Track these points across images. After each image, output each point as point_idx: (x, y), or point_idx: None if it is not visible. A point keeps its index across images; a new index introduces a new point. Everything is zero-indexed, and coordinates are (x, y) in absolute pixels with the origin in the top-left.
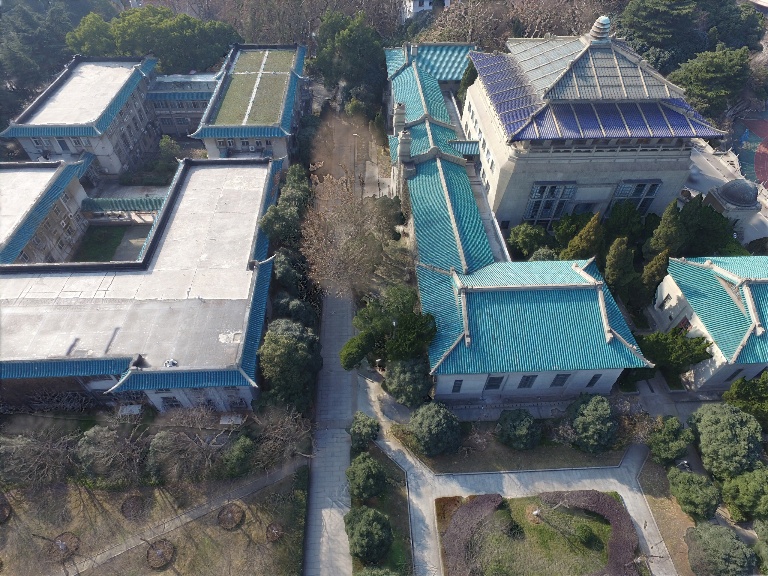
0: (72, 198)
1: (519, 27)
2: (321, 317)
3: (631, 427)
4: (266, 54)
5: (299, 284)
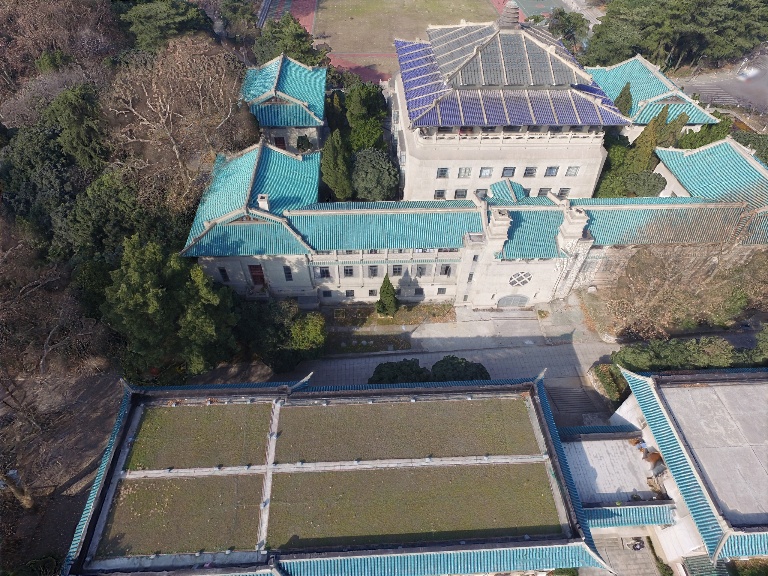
0: None
1: None
2: None
3: None
4: (147, 475)
5: None
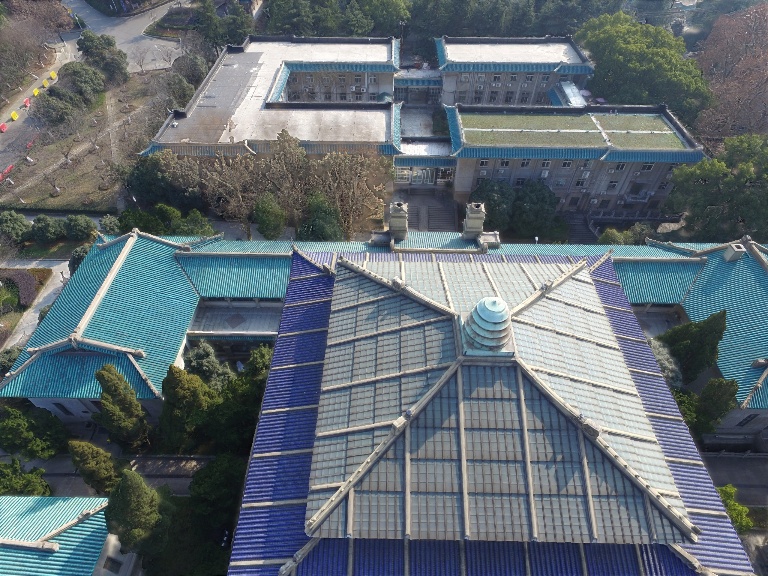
0: (378, 84)
1: None
2: None
3: None
4: (662, 132)
5: None
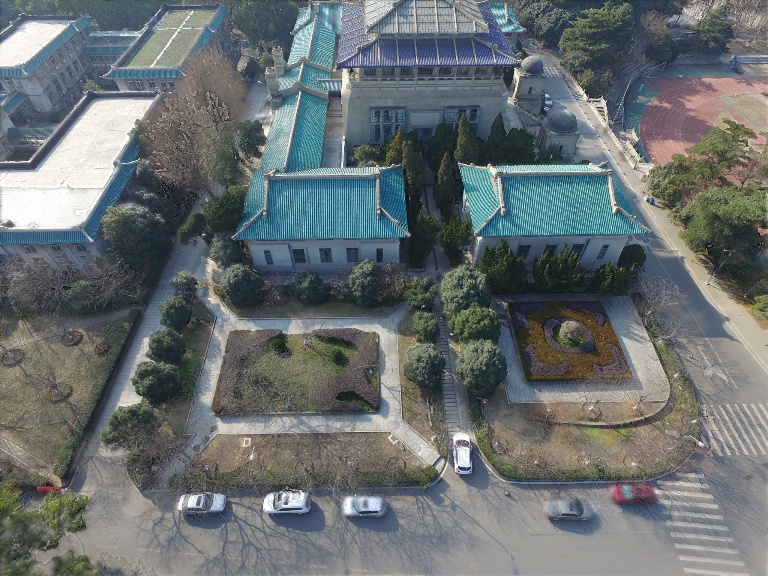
0: None
1: None
2: (187, 217)
3: (391, 283)
4: (191, 13)
5: (163, 186)
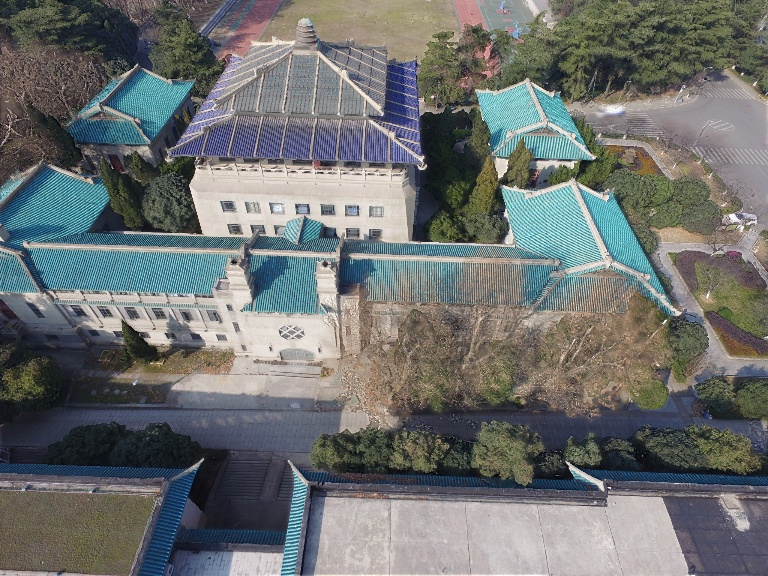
0: None
1: (39, 113)
2: None
3: None
4: None
5: None
